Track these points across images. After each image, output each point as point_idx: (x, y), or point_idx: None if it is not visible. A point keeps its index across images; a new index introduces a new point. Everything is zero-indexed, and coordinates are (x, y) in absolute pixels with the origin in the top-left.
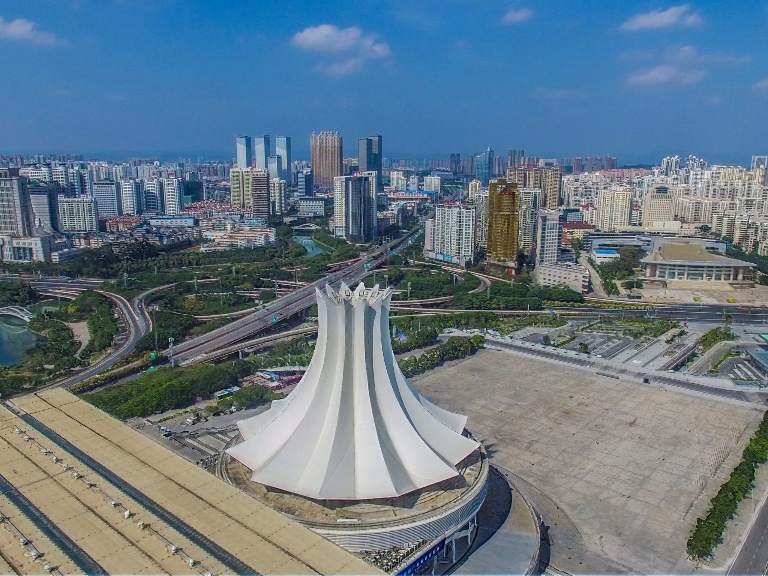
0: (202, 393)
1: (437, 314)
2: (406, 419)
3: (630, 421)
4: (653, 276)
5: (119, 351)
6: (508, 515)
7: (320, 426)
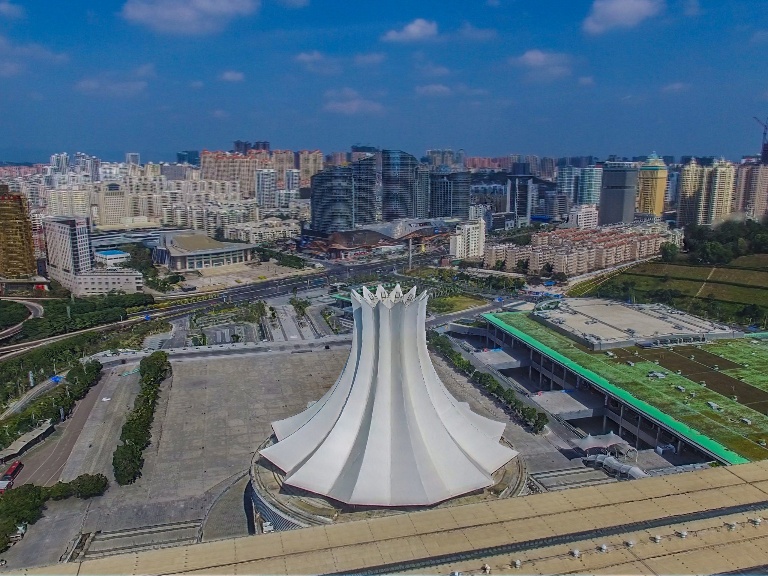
0: None
1: (38, 349)
2: None
3: None
4: (184, 268)
5: None
6: None
7: (418, 432)
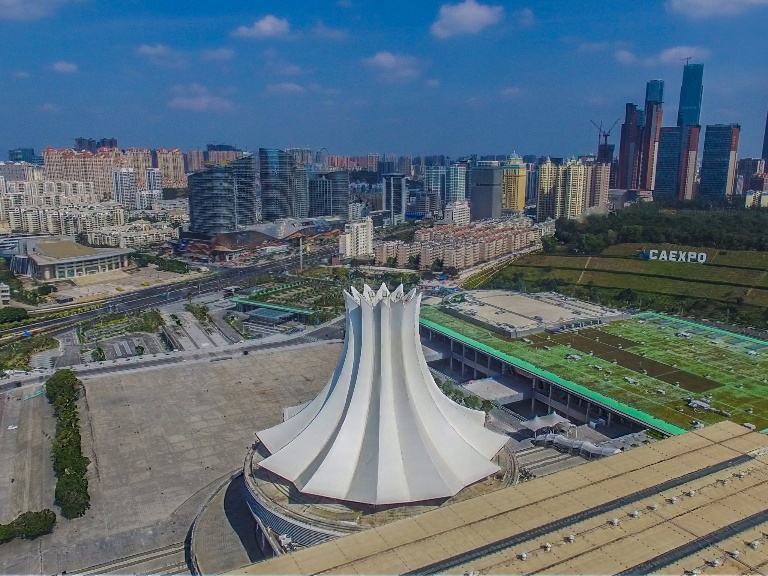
0: None
1: None
2: None
3: (304, 379)
4: (53, 278)
5: None
6: None
7: (422, 427)
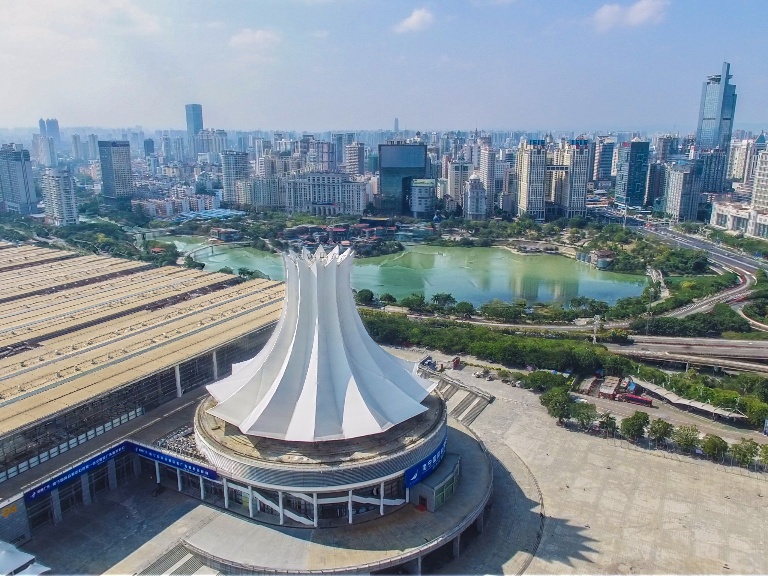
0: (529, 363)
1: None
2: (282, 376)
3: None
4: None
5: (622, 323)
6: (341, 547)
7: None
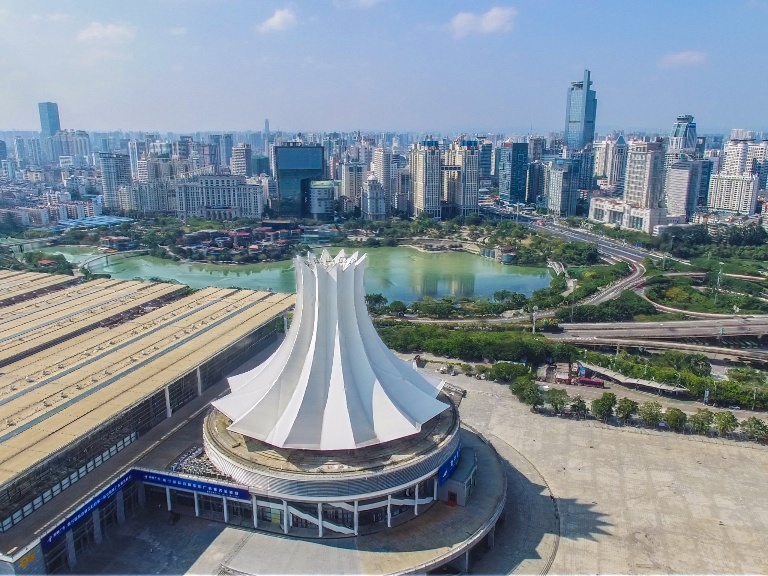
0: (486, 355)
1: None
2: (306, 385)
3: None
4: None
5: (547, 313)
6: (391, 552)
7: None
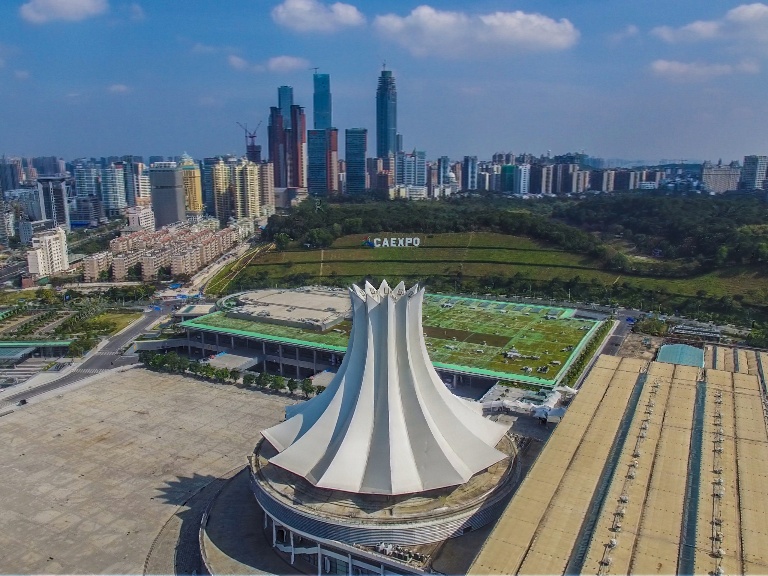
0: None
1: None
2: None
3: (136, 413)
4: None
5: None
6: None
7: None
